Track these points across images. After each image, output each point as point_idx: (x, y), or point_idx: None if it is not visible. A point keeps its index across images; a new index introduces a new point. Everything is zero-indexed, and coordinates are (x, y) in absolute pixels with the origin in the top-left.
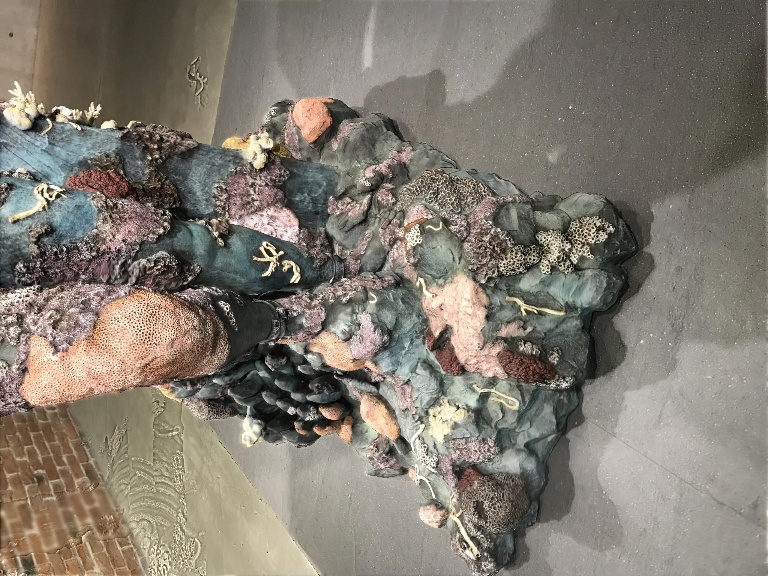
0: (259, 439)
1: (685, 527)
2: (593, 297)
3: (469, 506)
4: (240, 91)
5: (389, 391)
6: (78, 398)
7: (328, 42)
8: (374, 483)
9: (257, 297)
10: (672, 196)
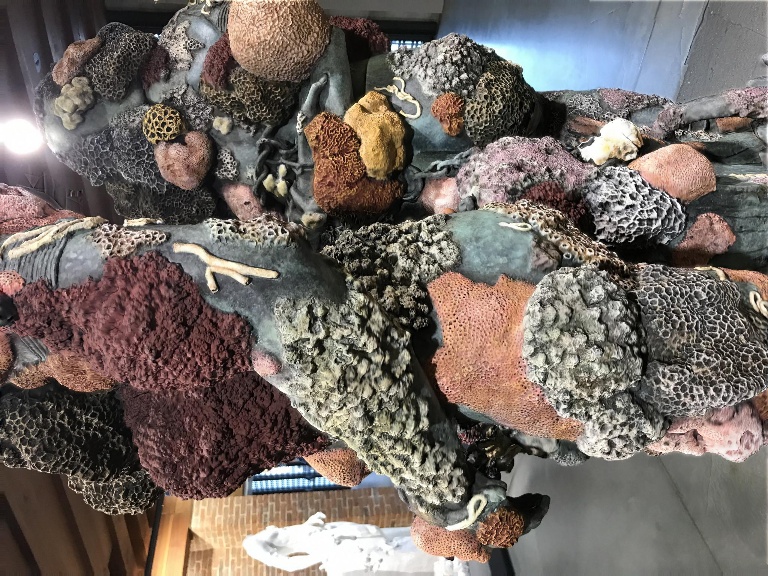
0: None
1: (755, 1)
2: None
3: None
4: None
5: None
6: None
7: None
8: None
9: None
10: None
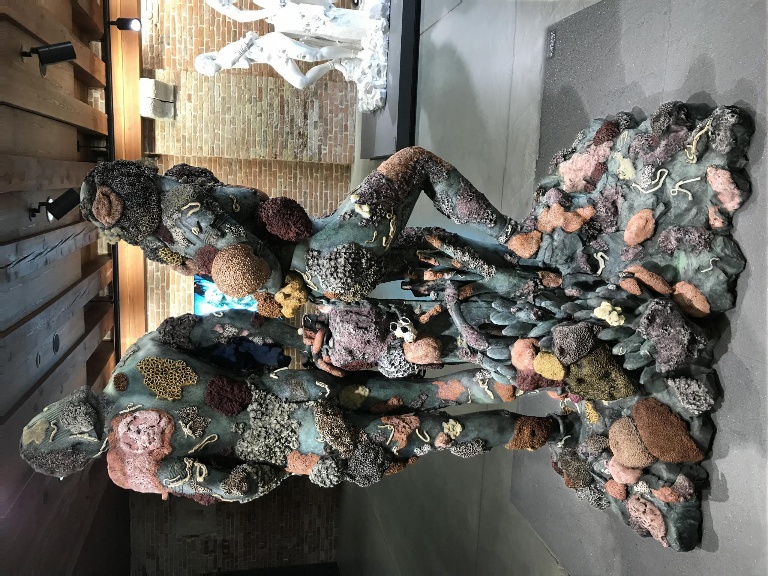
0: (615, 308)
1: None
2: (598, 124)
3: (656, 126)
4: (563, 529)
5: (623, 221)
6: (399, 167)
7: (549, 396)
8: (761, 283)
9: (517, 267)
10: (590, 121)
